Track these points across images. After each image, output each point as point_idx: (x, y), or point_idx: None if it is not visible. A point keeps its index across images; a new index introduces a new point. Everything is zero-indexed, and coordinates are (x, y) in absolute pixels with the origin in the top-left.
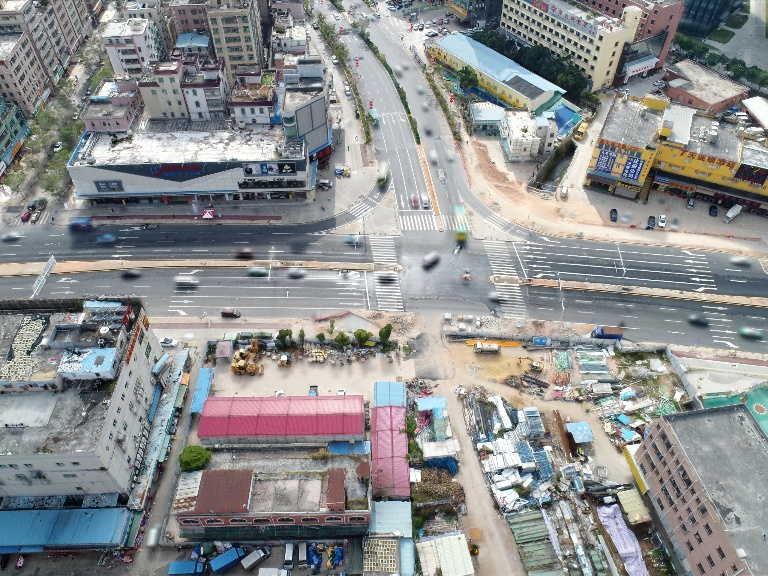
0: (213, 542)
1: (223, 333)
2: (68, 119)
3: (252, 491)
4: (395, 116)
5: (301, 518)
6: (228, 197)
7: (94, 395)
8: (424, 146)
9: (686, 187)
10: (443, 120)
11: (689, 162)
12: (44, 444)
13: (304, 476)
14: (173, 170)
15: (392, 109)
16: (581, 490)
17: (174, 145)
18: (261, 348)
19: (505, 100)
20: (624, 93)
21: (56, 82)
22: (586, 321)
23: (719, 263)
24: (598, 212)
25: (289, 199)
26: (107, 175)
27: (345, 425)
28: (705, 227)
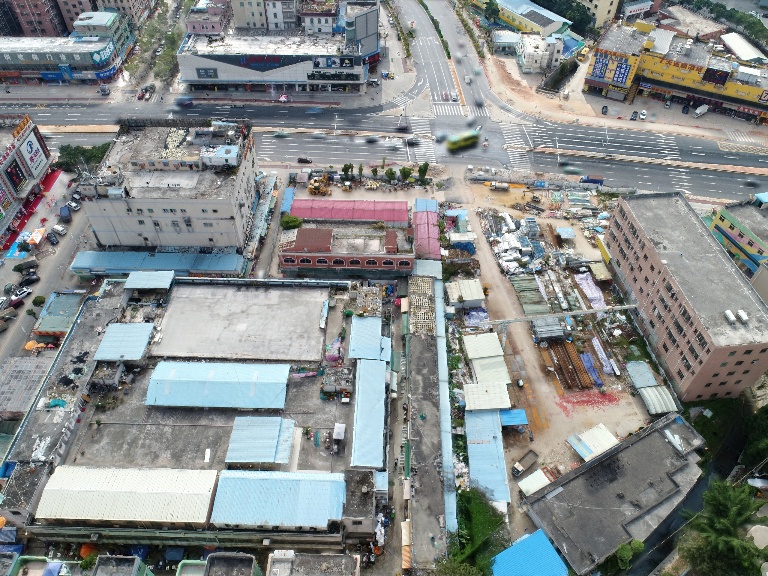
0: (303, 278)
1: (300, 172)
2: (164, 34)
3: (332, 243)
4: (430, 39)
5: (366, 261)
6: (298, 88)
7: (224, 174)
8: (454, 60)
9: (665, 91)
10: (470, 43)
11: (667, 68)
12: (195, 196)
13: (368, 237)
14: (258, 61)
15: (428, 35)
16: (563, 262)
17: (257, 44)
18: (329, 180)
19: (522, 30)
20: (619, 20)
21: (152, 6)
22: (576, 174)
23: (685, 142)
24: (592, 108)
25: (346, 91)
26: (207, 63)
27: (395, 216)
28: (677, 120)
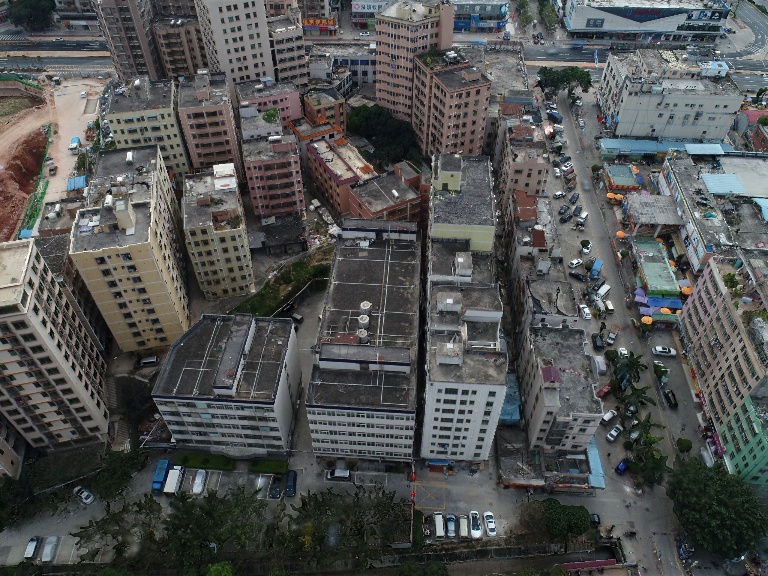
0: None
1: None
2: None
3: None
4: (744, 5)
5: None
6: (663, 38)
7: (719, 82)
8: None
9: None
10: None
11: None
12: None
13: None
14: (642, 13)
15: None
16: None
17: (633, 1)
18: None
19: None
20: None
21: None
22: None
23: None
24: None
25: (703, 41)
26: (598, 14)
27: None
28: None
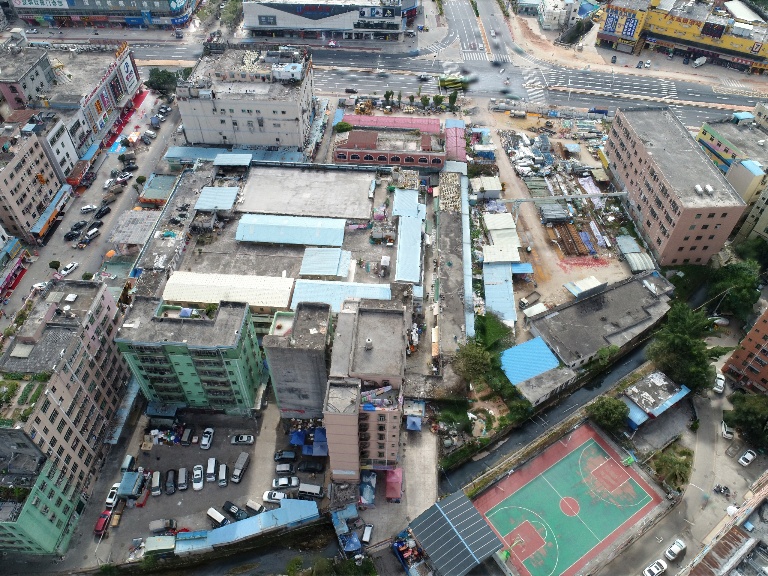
0: None
1: None
2: None
3: (377, 144)
4: (461, 1)
5: (405, 158)
6: (344, 36)
7: (291, 85)
8: (481, 18)
9: (668, 44)
10: (496, 5)
11: (670, 24)
12: None
13: (406, 140)
14: (312, 10)
15: None
16: (569, 168)
17: None
18: (373, 105)
19: None
20: None
21: None
22: (585, 107)
23: (683, 86)
24: (603, 58)
25: (386, 40)
26: (268, 11)
27: (429, 128)
28: (678, 69)
